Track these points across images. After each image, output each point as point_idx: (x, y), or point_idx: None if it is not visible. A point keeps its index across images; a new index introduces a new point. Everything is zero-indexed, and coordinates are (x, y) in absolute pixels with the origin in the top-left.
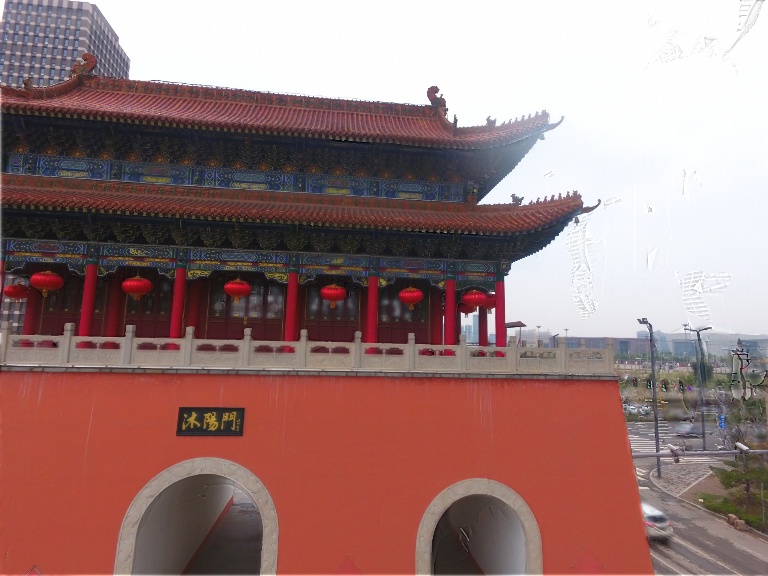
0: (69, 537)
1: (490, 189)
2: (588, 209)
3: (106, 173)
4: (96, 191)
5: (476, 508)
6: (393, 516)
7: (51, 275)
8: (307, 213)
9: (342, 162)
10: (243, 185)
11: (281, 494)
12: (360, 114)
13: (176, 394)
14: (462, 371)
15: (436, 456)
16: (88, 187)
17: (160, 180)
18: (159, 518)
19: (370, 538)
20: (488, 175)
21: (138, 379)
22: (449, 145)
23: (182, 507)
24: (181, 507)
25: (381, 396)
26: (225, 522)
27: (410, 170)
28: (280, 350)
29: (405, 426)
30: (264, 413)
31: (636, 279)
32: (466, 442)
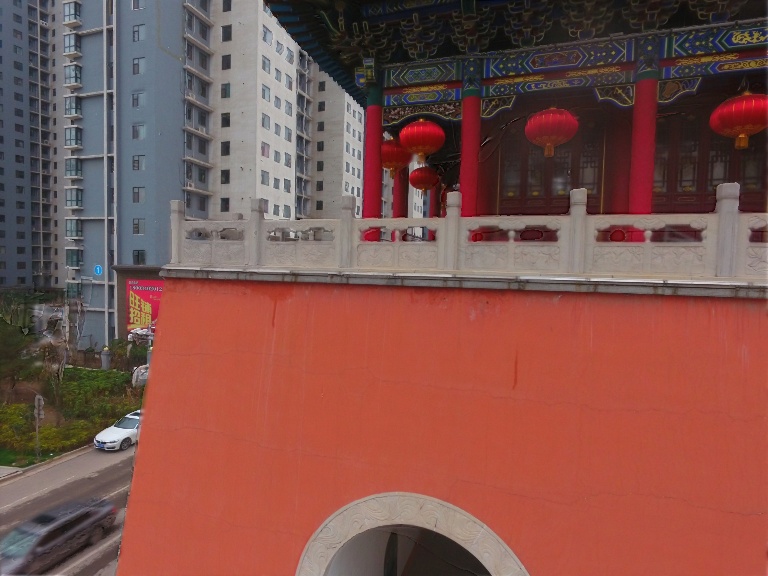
0: None
1: None
2: None
3: None
4: None
5: None
6: None
7: None
8: None
9: None
10: None
11: None
12: None
13: None
14: None
15: None
16: None
17: None
18: None
19: None
20: None
21: None
22: None
23: None
24: None
25: None
26: None
27: None
28: None
29: None
30: None
31: None
32: None
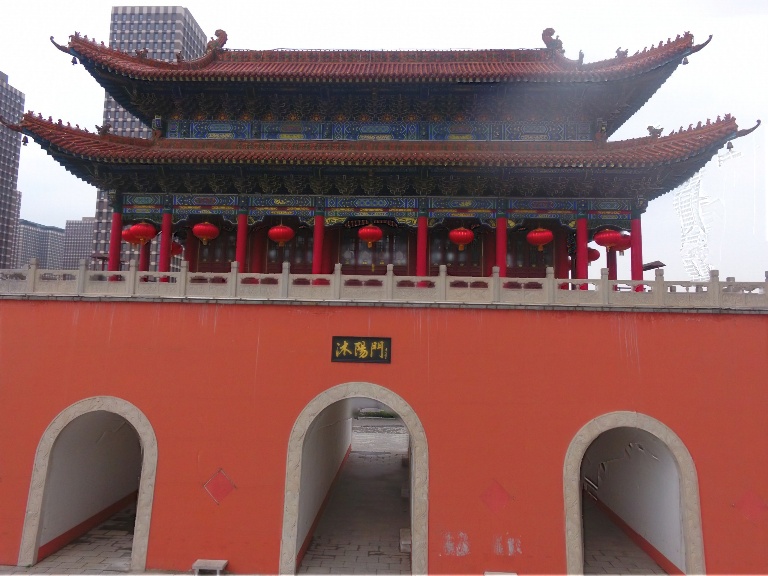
0: (246, 446)
1: (614, 130)
2: (744, 132)
3: (248, 133)
4: (241, 150)
5: (624, 441)
6: (538, 444)
7: (210, 225)
8: (440, 154)
9: (464, 108)
10: (369, 137)
11: (429, 418)
12: (473, 64)
13: (329, 324)
14: (605, 305)
15: (580, 388)
16: (234, 146)
17: (294, 137)
18: (313, 440)
19: (516, 463)
20: (615, 113)
21: (295, 311)
22: (580, 78)
23: (324, 438)
24: (324, 437)
25: (522, 329)
26: (349, 464)
27: (533, 111)
28: (421, 285)
29: (547, 358)
30: (409, 343)
31: (757, 242)
32: (611, 375)
